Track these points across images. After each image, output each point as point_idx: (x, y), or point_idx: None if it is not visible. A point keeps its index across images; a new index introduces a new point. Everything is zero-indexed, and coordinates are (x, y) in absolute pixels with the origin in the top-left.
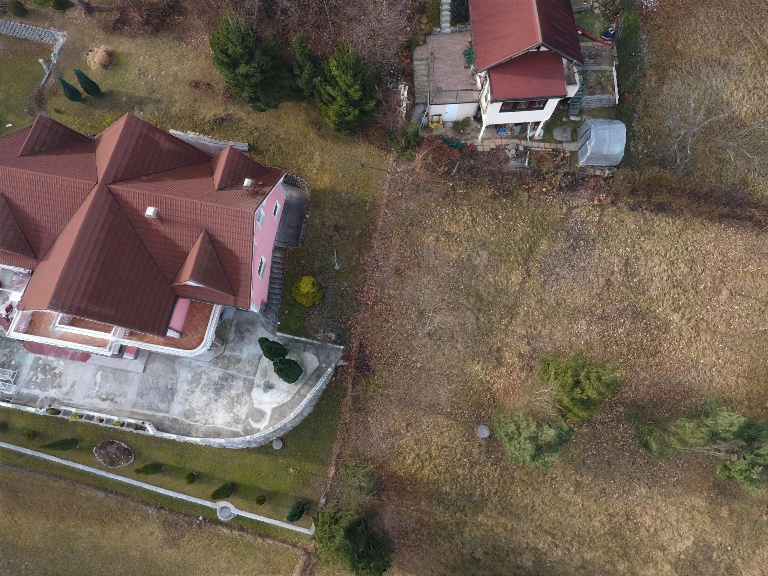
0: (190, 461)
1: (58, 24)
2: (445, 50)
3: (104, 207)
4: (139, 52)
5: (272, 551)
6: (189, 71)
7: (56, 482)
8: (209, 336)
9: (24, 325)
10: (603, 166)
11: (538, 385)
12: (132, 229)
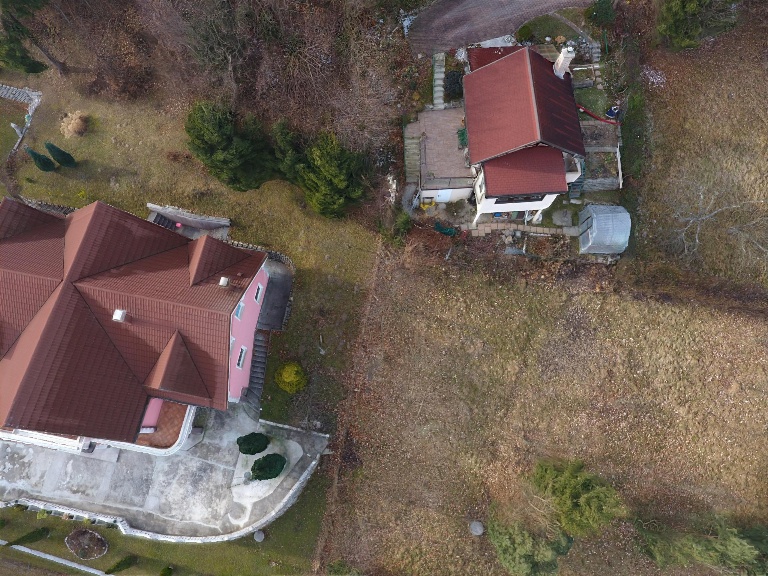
0: (167, 553)
1: (33, 84)
2: (438, 129)
3: (69, 307)
4: (116, 119)
5: None
6: (167, 142)
7: (26, 571)
8: (185, 433)
9: None
10: (605, 254)
11: (535, 488)
12: (100, 328)
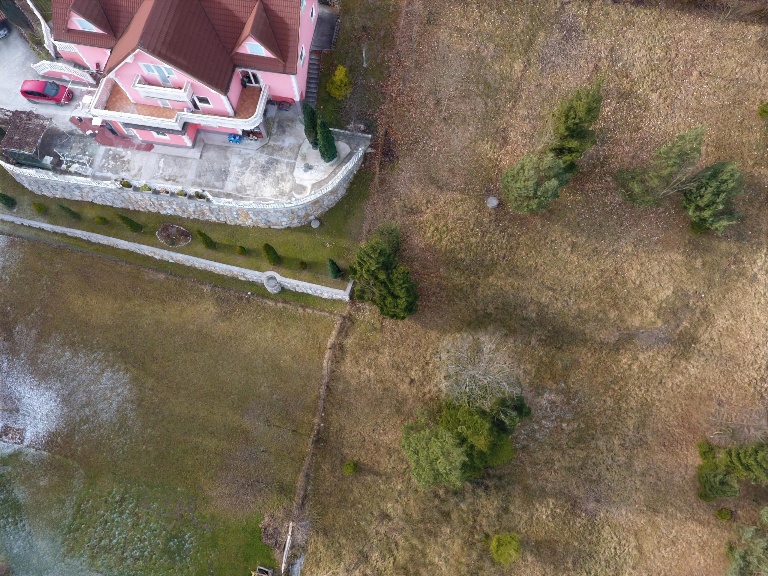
0: (240, 240)
1: None
2: None
3: None
4: None
5: (312, 320)
6: None
7: (122, 267)
8: (260, 110)
9: (101, 108)
10: None
11: None
12: (198, 3)
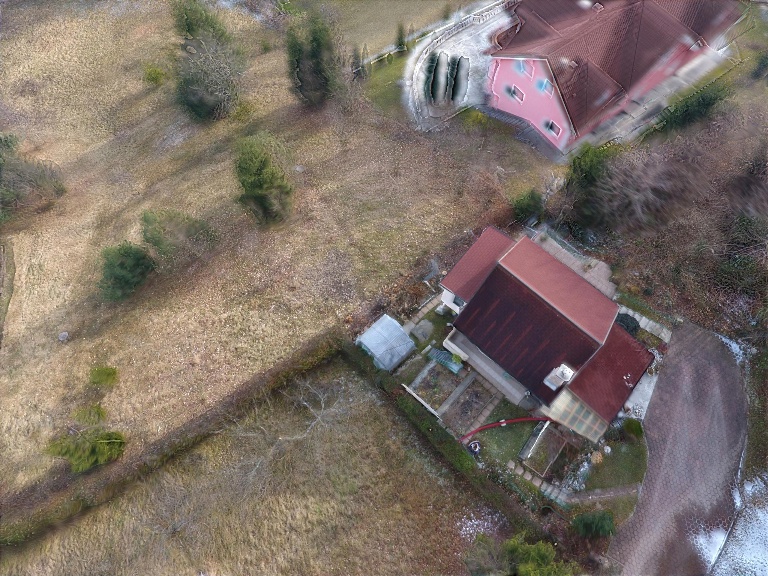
0: None
1: None
2: None
3: None
4: None
5: None
6: None
7: None
8: None
9: None
10: None
11: None
12: None
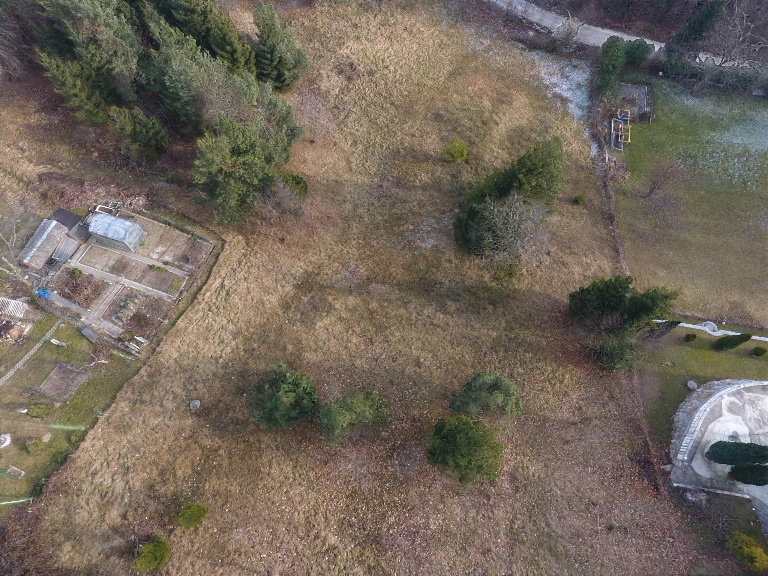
0: (764, 367)
1: None
2: None
3: None
4: None
5: None
6: None
7: None
8: None
9: None
10: None
11: None
12: None
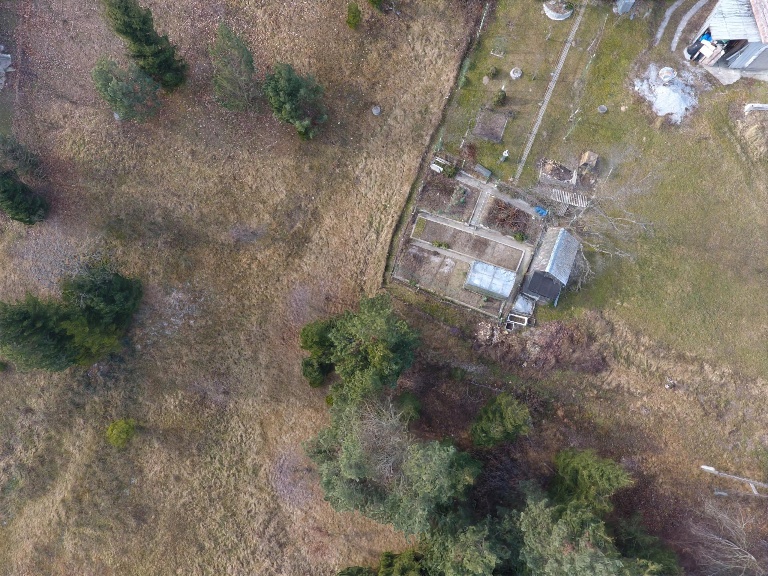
0: None
1: None
2: None
3: None
4: None
5: None
6: None
7: None
8: None
9: None
10: None
11: None
12: None
